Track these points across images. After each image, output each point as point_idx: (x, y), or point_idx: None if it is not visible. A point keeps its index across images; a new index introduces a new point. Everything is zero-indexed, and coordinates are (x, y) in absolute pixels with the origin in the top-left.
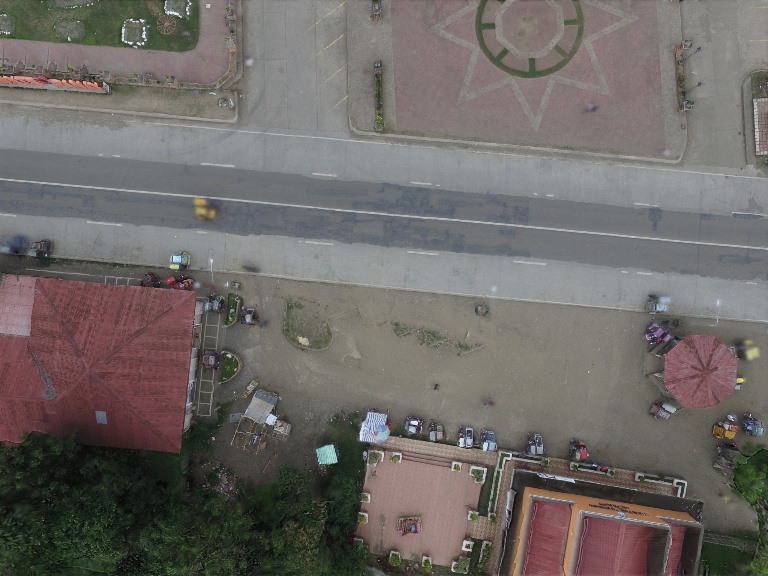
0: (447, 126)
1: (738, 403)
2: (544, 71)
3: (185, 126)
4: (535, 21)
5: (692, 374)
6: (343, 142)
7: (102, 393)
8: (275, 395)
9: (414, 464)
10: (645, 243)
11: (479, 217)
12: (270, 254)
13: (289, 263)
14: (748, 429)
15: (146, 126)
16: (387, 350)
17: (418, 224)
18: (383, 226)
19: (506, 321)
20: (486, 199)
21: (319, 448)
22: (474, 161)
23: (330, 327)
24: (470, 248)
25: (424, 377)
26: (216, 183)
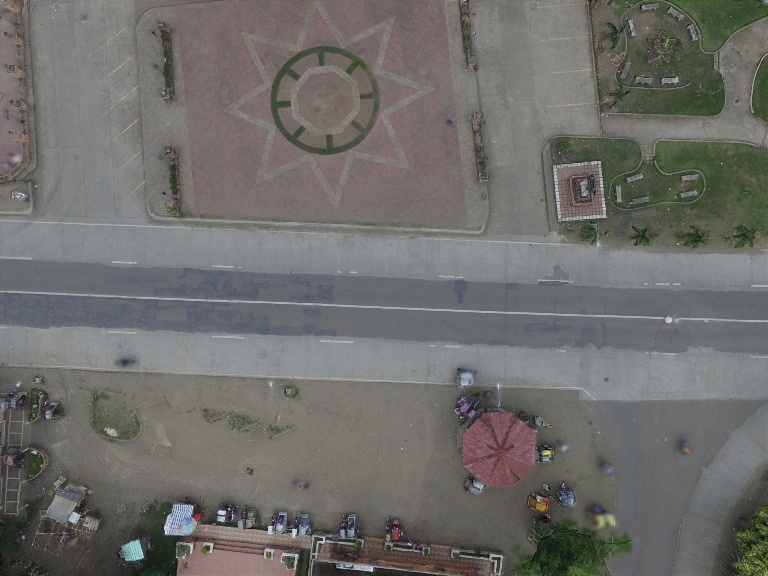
0: (246, 207)
1: (553, 472)
2: (342, 147)
3: None
4: (331, 97)
5: (488, 453)
6: (142, 228)
7: None
8: (83, 490)
9: (226, 553)
10: (452, 315)
11: (283, 298)
12: (72, 346)
13: (92, 354)
14: (560, 499)
15: None
16: (198, 437)
17: (221, 308)
18: (186, 312)
19: (316, 401)
20: (289, 279)
21: None
22: (276, 241)
23: (138, 417)
24: (276, 330)
25: (237, 462)
26: (14, 276)
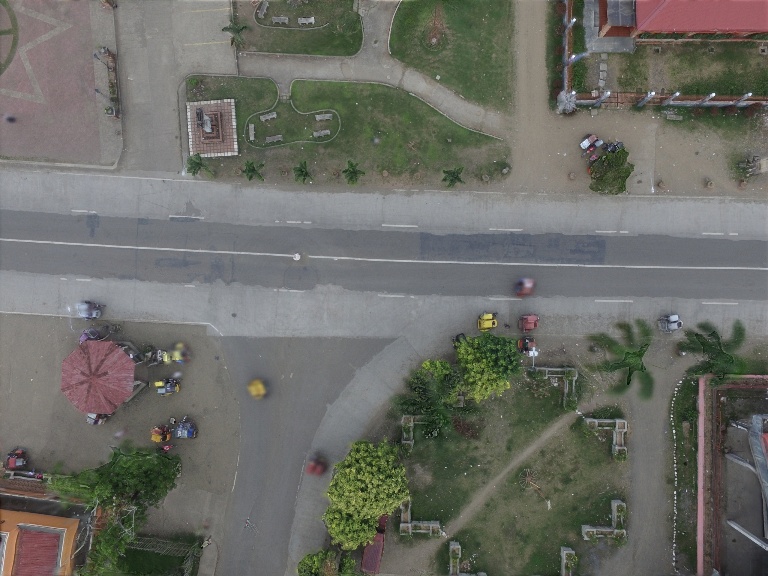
0: None
1: (180, 406)
2: None
3: None
4: None
5: (80, 380)
6: None
7: None
8: None
9: None
10: (83, 249)
11: None
12: None
13: None
14: None
15: None
16: None
17: None
18: None
19: None
20: None
21: None
22: None
23: None
24: None
25: None
26: None
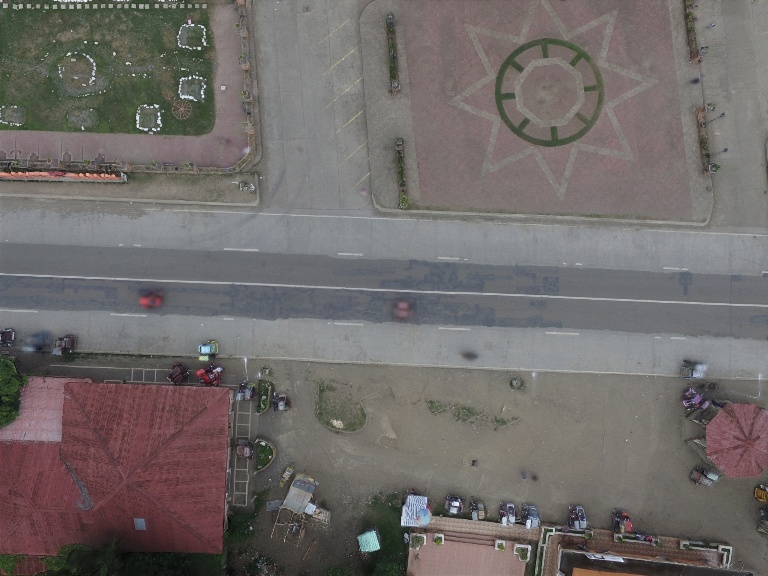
0: (472, 199)
1: None
2: (567, 139)
3: (206, 211)
4: (555, 89)
5: (735, 444)
6: (368, 220)
7: (140, 501)
8: (312, 481)
9: (457, 544)
10: (677, 307)
11: (509, 289)
12: (299, 338)
13: (319, 346)
14: None
15: (166, 213)
16: (423, 428)
17: (448, 300)
18: (412, 303)
19: (541, 393)
20: (515, 271)
21: (360, 535)
22: (501, 233)
23: (364, 408)
24: (501, 321)
25: (461, 454)
26: (241, 268)
